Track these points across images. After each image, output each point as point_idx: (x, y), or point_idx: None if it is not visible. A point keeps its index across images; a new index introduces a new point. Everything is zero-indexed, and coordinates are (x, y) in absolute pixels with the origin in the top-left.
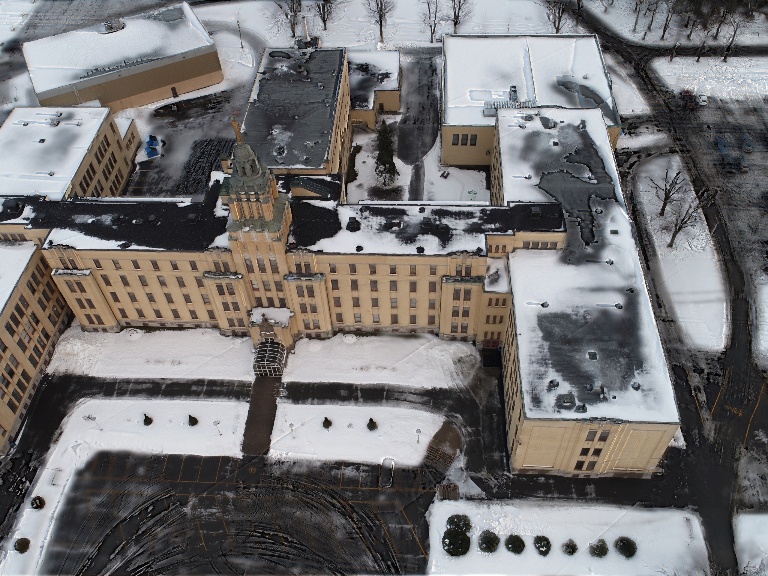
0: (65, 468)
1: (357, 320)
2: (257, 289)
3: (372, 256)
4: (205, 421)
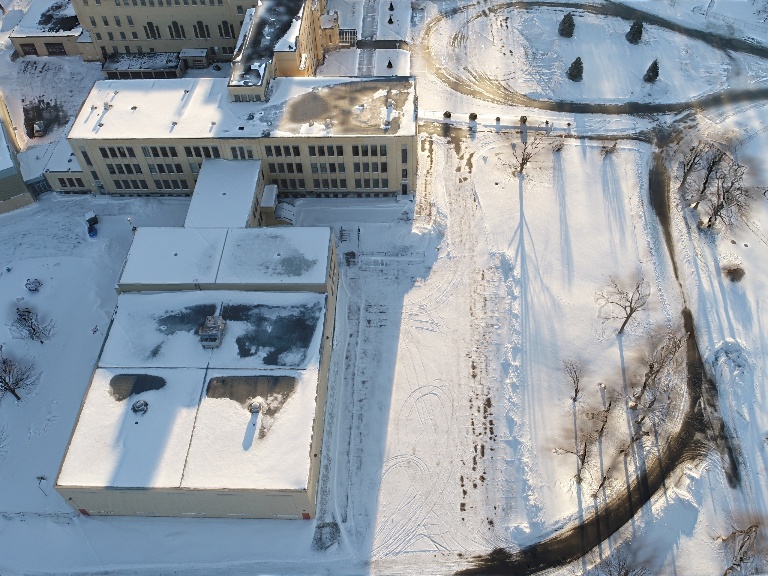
0: None
1: None
2: None
3: None
4: None
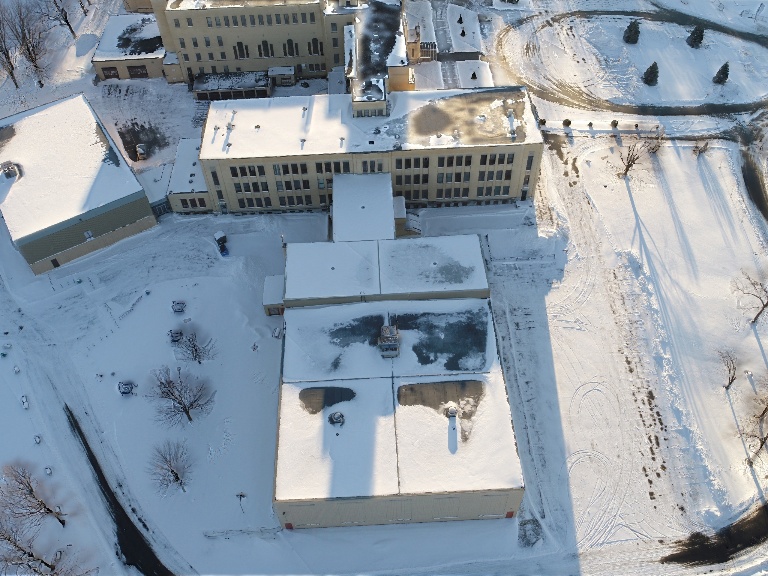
0: None
1: None
2: None
3: None
4: None
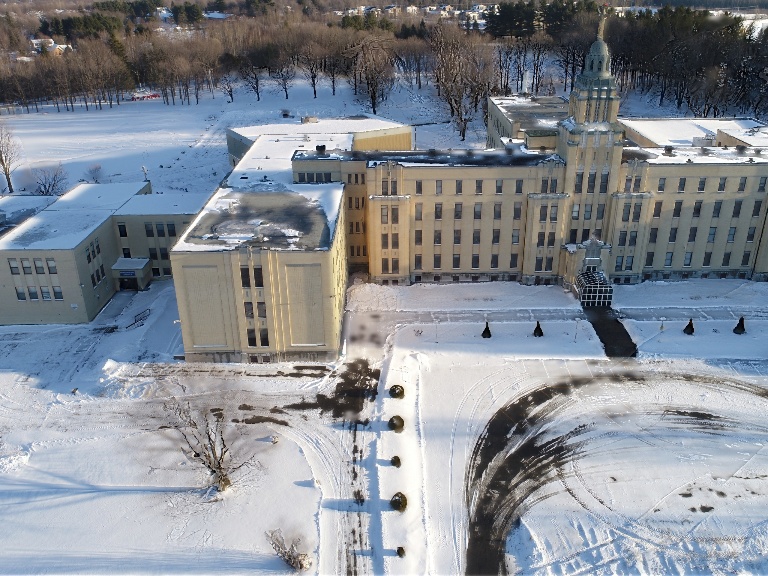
0: (410, 371)
1: (666, 264)
2: (576, 218)
3: (706, 166)
4: (550, 334)
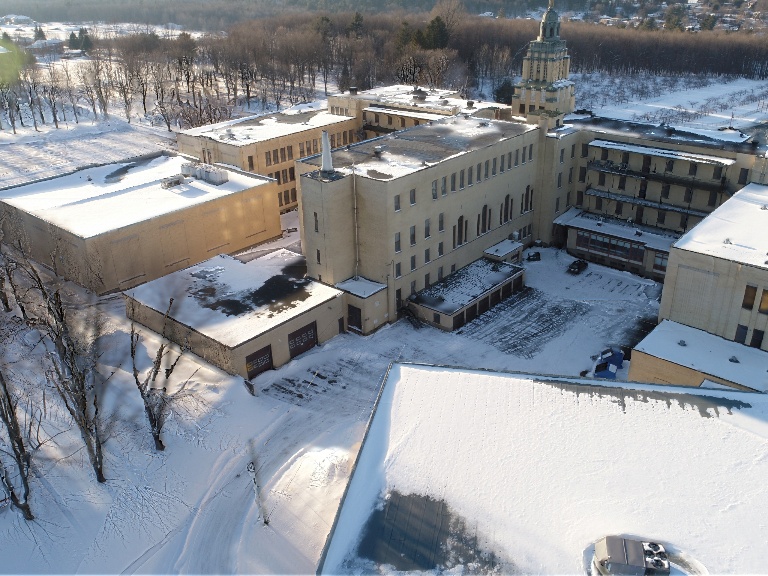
0: None
1: None
2: None
3: None
4: None
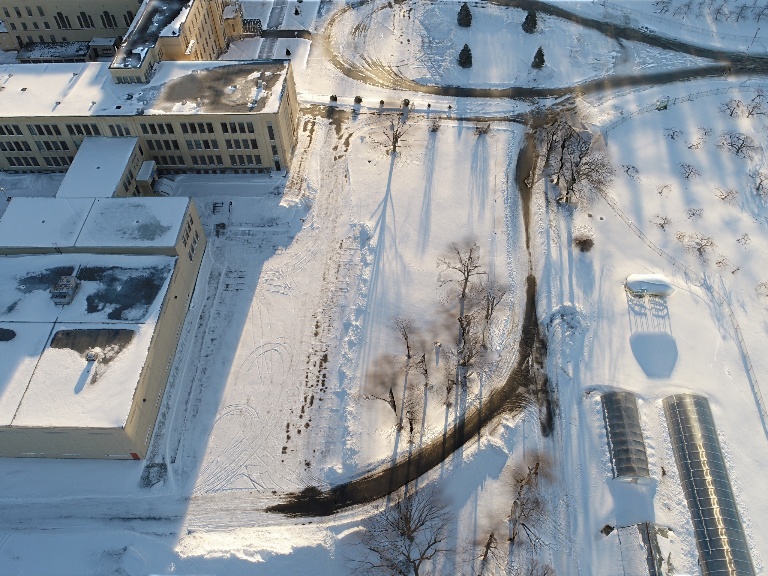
0: None
1: None
2: None
3: None
4: None
